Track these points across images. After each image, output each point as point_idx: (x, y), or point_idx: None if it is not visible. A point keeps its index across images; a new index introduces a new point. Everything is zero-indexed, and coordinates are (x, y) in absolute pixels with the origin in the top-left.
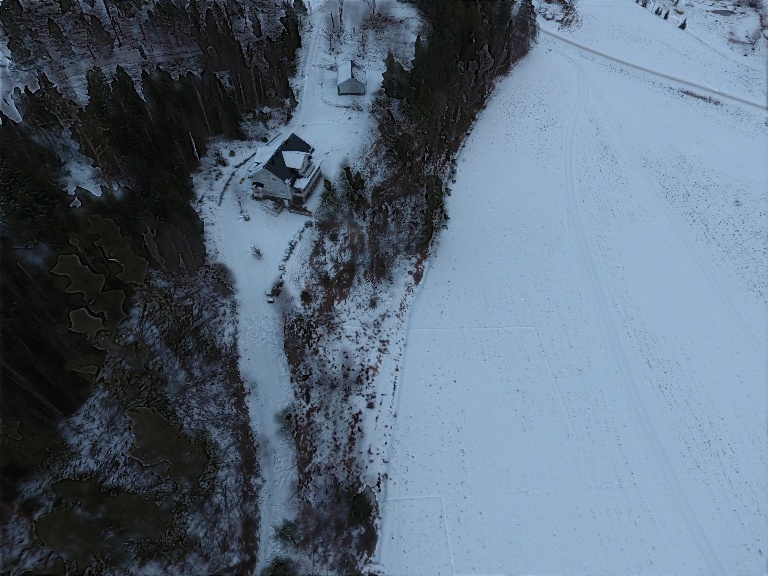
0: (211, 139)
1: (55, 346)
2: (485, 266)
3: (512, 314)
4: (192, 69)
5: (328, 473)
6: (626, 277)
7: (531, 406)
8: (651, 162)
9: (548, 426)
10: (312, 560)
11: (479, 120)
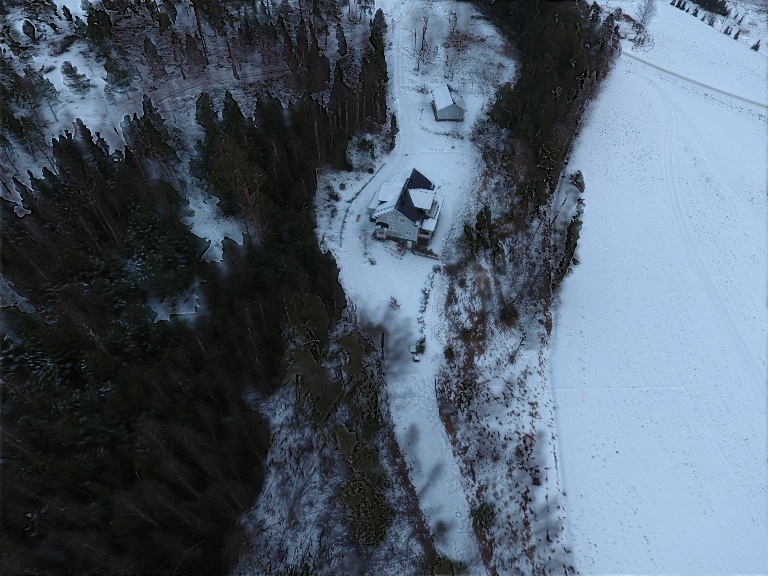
0: (319, 170)
1: (231, 429)
2: (615, 314)
3: (657, 371)
4: (284, 91)
5: (512, 567)
6: (766, 329)
7: (704, 483)
8: (758, 197)
9: (729, 508)
10: None
11: (574, 148)
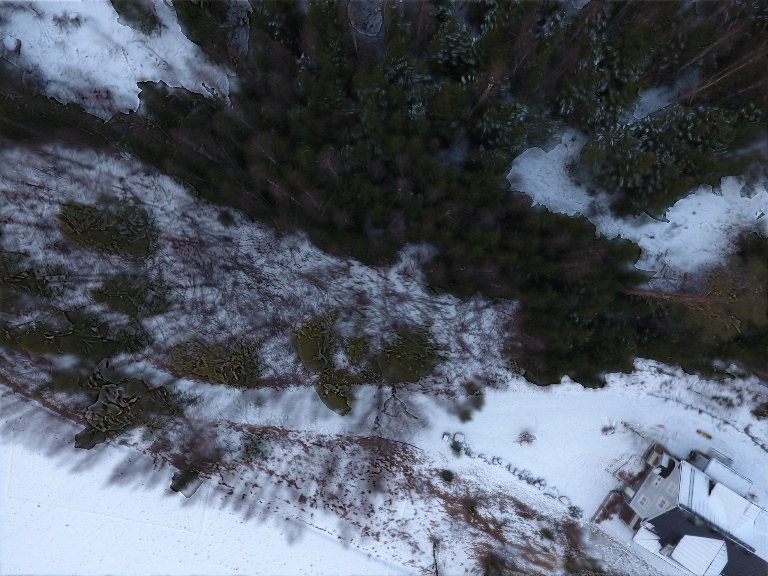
0: None
1: (369, 234)
2: None
3: None
4: None
5: (241, 446)
6: None
7: None
8: None
9: None
10: (170, 420)
11: None
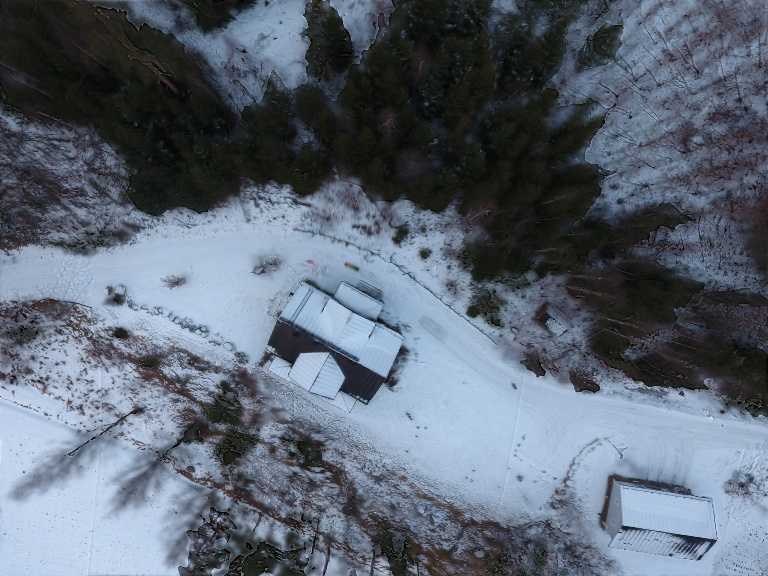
0: None
1: None
2: None
3: (108, 571)
4: (749, 177)
5: None
6: None
7: None
8: None
9: None
10: None
11: None
